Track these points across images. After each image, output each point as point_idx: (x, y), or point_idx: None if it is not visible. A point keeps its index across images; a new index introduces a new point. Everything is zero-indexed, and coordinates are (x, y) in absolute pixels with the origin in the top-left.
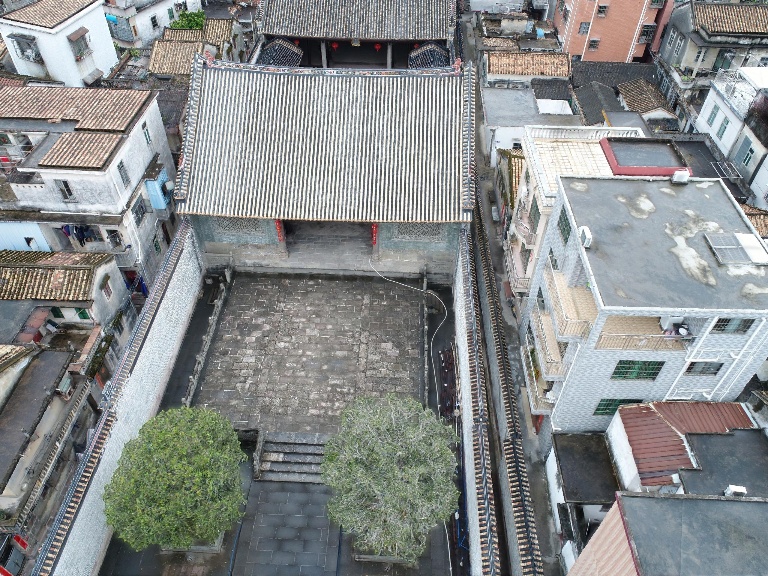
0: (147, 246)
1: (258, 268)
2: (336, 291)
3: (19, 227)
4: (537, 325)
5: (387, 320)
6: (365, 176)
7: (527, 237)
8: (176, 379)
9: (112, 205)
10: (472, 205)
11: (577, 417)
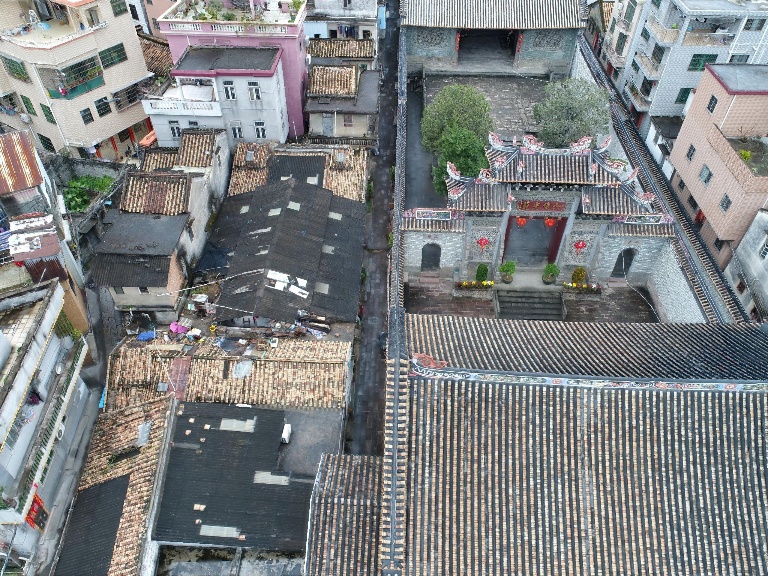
0: (377, 50)
1: (440, 72)
2: (494, 82)
3: (314, 26)
4: (641, 58)
5: (531, 94)
6: (517, 2)
7: (625, 27)
8: (408, 122)
9: (372, 11)
10: (587, 16)
11: (665, 106)
